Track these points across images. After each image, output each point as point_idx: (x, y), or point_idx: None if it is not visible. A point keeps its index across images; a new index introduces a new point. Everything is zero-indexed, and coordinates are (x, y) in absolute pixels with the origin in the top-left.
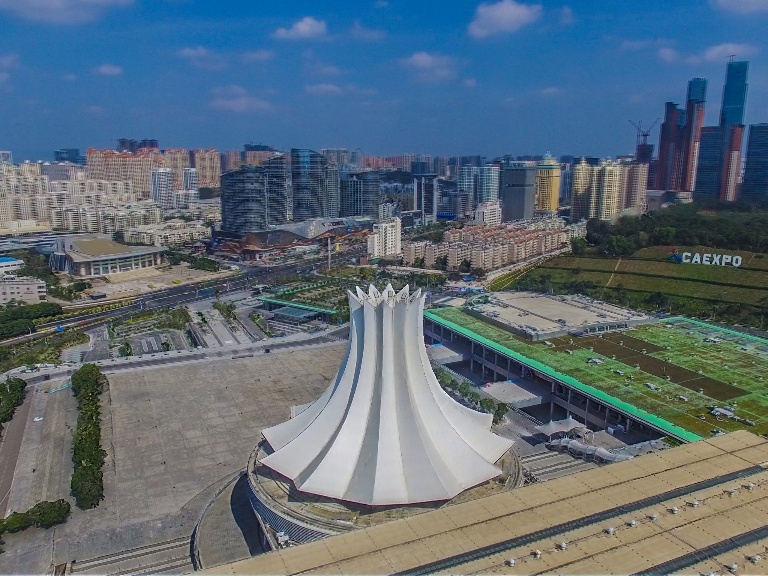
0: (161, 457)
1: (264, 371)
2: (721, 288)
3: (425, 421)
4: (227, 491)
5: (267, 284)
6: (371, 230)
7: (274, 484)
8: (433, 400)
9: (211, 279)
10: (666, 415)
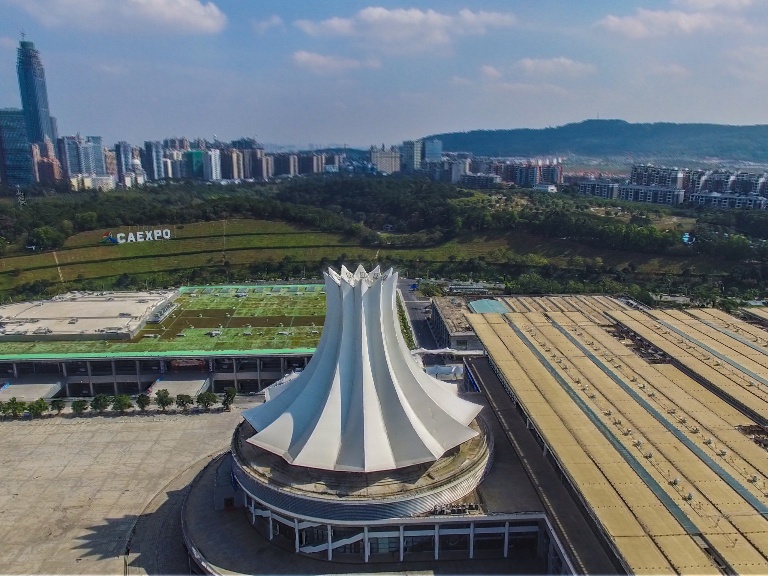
0: None
1: None
2: (170, 259)
3: None
4: None
5: None
6: None
7: (376, 487)
8: None
9: None
10: None
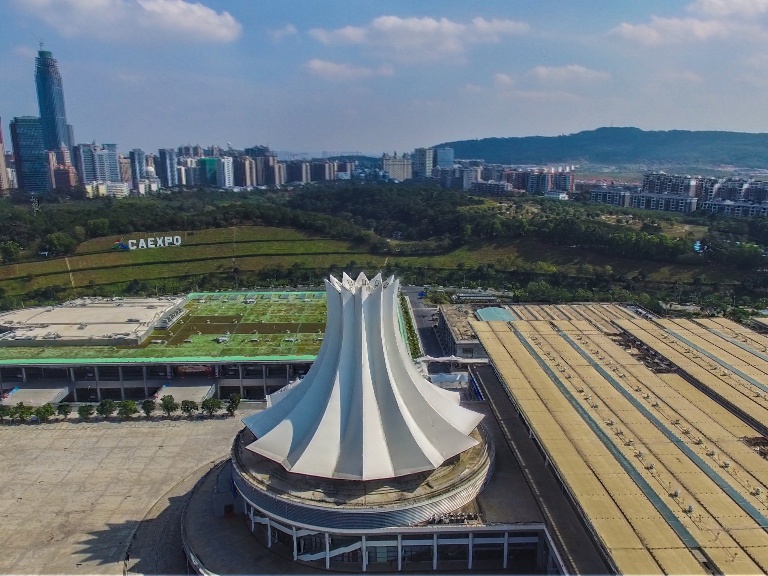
0: None
1: None
2: (181, 265)
3: None
4: None
5: None
6: None
7: (374, 496)
8: None
9: None
10: None
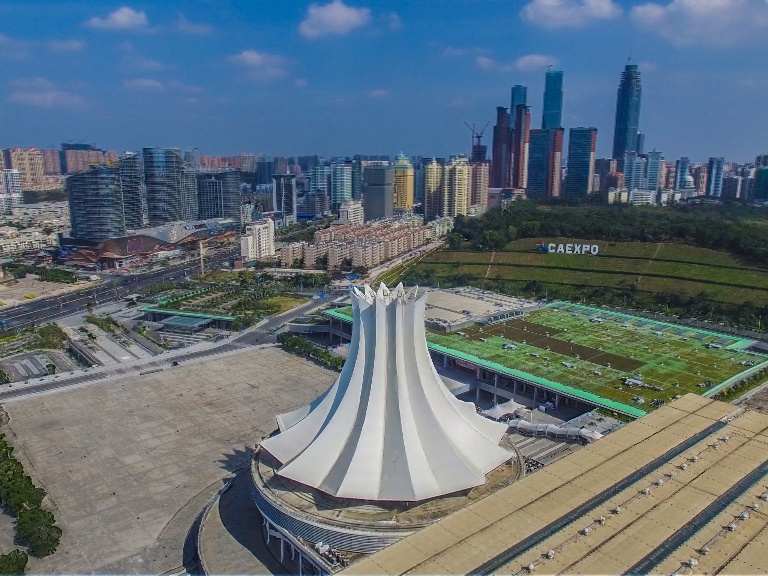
0: (107, 488)
1: (182, 385)
2: (585, 274)
3: (436, 414)
4: (213, 512)
5: (140, 293)
6: (244, 232)
7: (294, 495)
8: (441, 393)
9: (71, 291)
10: (591, 389)
